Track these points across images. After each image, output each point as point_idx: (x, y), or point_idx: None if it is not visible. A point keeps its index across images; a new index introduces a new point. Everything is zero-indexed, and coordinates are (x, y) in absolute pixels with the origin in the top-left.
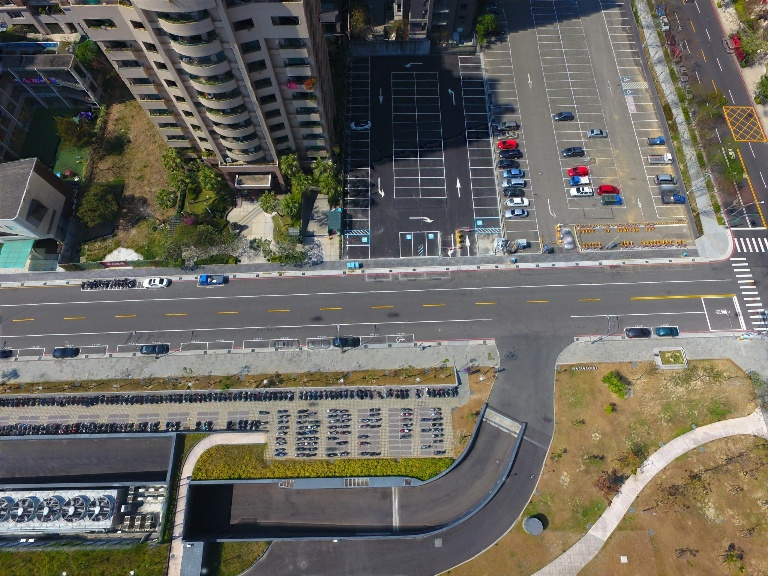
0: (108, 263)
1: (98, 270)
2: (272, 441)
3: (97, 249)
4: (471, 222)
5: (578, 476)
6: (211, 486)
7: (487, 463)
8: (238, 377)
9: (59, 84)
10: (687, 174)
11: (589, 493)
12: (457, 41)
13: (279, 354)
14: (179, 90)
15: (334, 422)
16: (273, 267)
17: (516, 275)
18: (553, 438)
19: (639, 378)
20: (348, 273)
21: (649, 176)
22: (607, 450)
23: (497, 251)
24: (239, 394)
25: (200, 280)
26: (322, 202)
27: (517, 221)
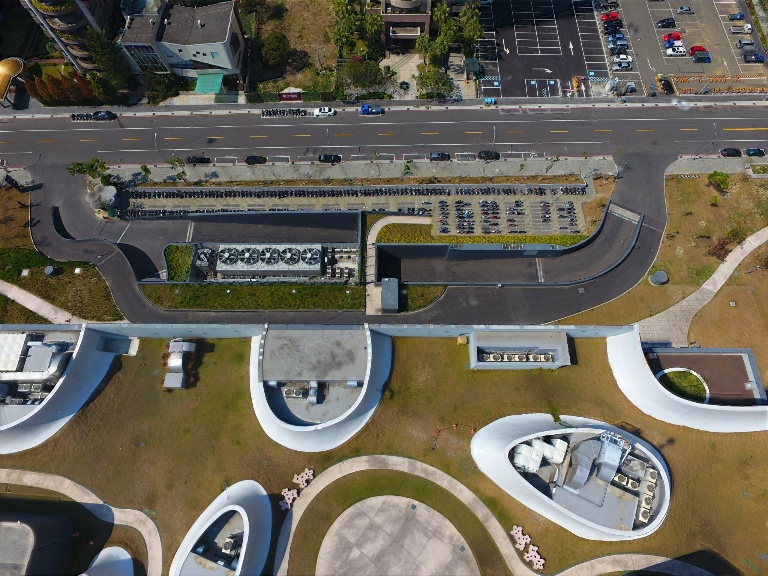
0: (284, 95)
1: (274, 103)
2: (436, 223)
3: (271, 88)
4: (584, 73)
5: (690, 249)
6: (388, 255)
7: (614, 242)
8: (402, 179)
9: None
10: (764, 40)
11: (700, 260)
12: None
13: (434, 164)
14: None
15: (486, 210)
16: (421, 103)
17: (626, 111)
18: (667, 225)
19: (734, 184)
20: (484, 108)
21: (732, 42)
22: (712, 232)
23: (608, 94)
24: (405, 190)
25: (363, 109)
26: (455, 59)
27: (623, 73)
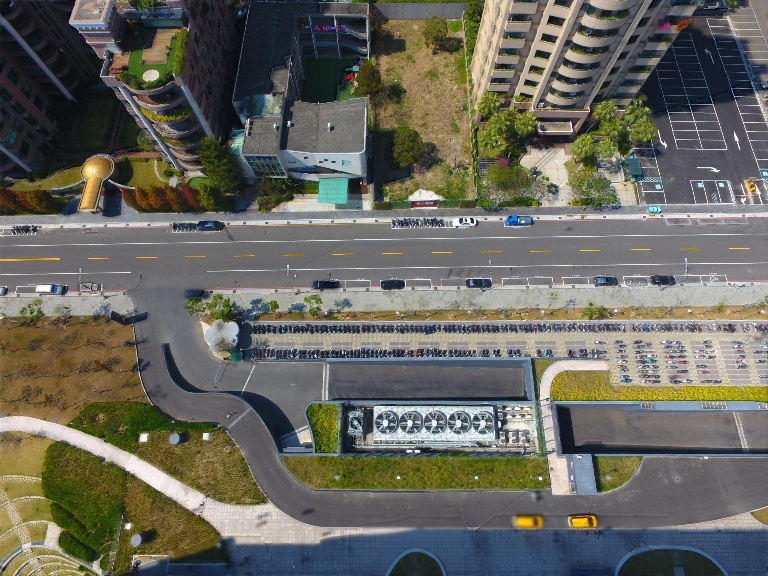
0: (419, 202)
1: (404, 210)
2: (614, 369)
3: (398, 190)
4: (757, 173)
5: None
6: (561, 409)
7: None
8: (566, 310)
9: (347, 32)
10: None
11: None
12: (703, 4)
13: (600, 290)
14: (555, 28)
15: (671, 352)
16: (574, 210)
17: None
18: None
19: None
20: (648, 217)
21: None
22: None
23: None
24: (573, 325)
25: (510, 220)
26: None
27: None
